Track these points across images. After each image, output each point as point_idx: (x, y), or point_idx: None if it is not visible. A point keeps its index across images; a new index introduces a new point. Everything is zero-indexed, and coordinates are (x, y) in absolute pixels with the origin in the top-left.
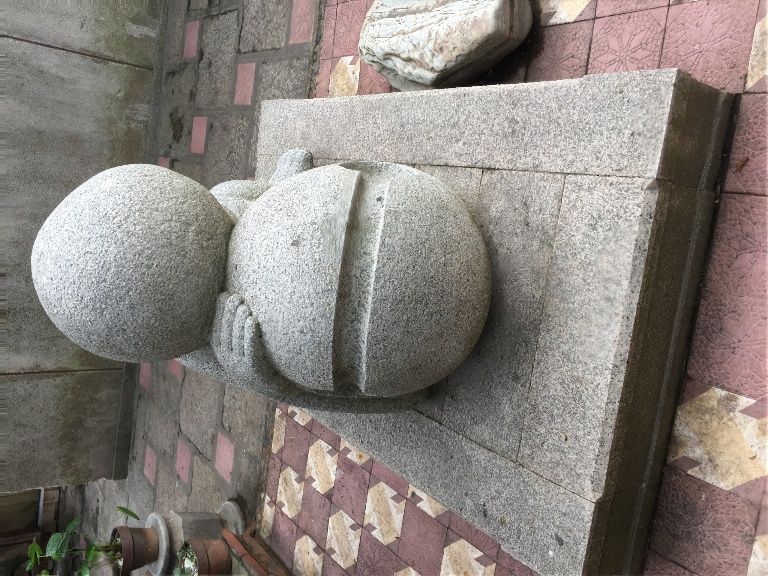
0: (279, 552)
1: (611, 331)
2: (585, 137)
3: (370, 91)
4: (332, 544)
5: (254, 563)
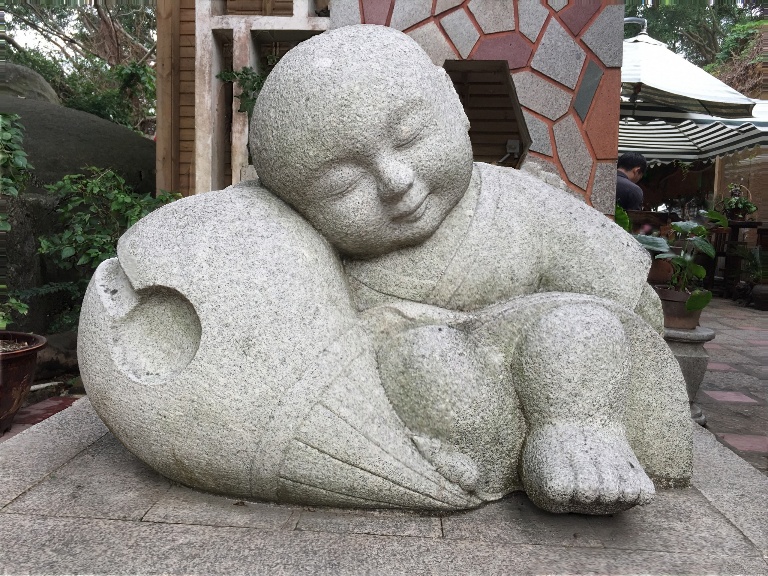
0: None
1: (6, 445)
2: None
3: None
4: None
5: None
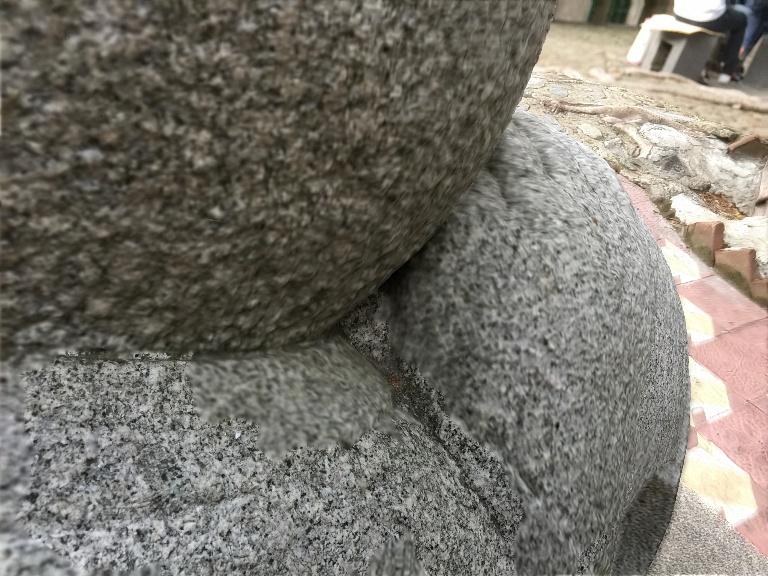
0: None
1: None
2: None
3: None
4: None
5: None
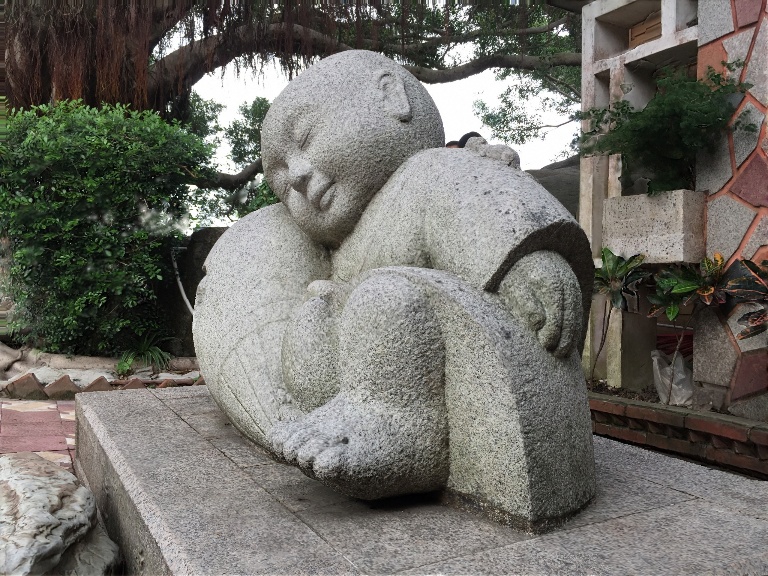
0: None
1: None
2: None
3: None
4: None
5: None
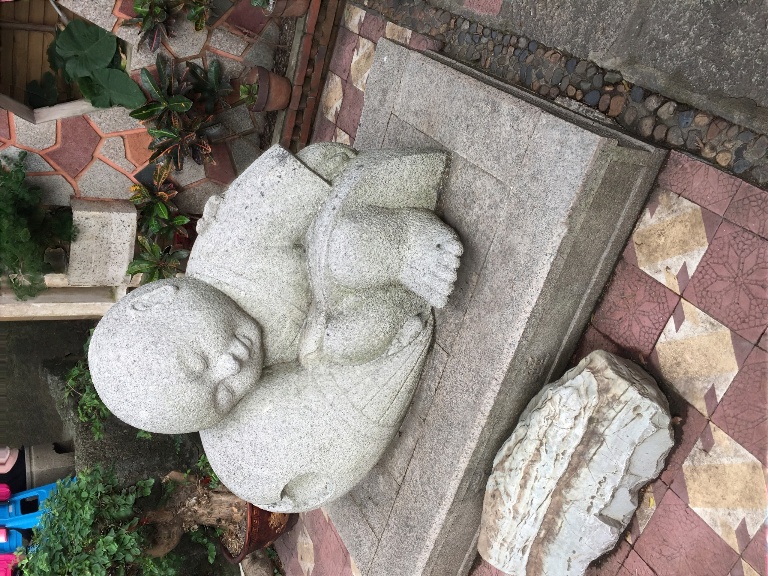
0: (337, 45)
1: None
2: (388, 567)
3: (624, 297)
4: (338, 138)
5: (307, 51)
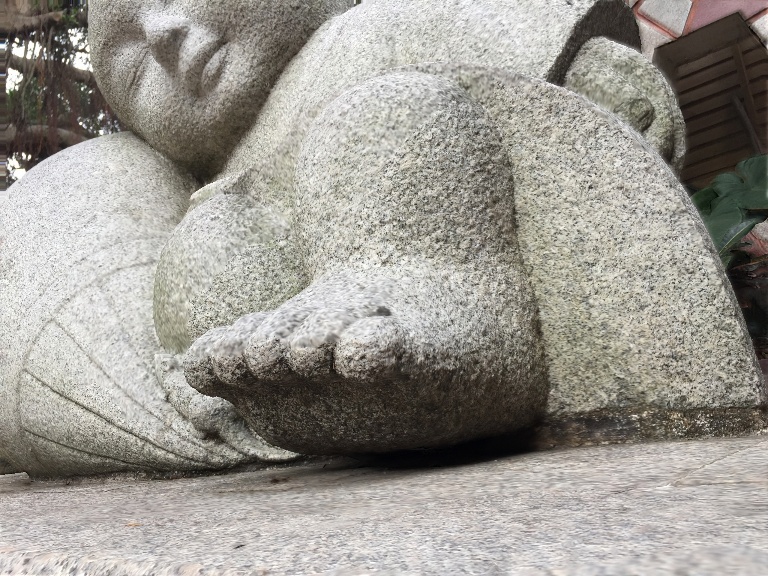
0: None
1: None
2: None
3: None
4: None
5: None
